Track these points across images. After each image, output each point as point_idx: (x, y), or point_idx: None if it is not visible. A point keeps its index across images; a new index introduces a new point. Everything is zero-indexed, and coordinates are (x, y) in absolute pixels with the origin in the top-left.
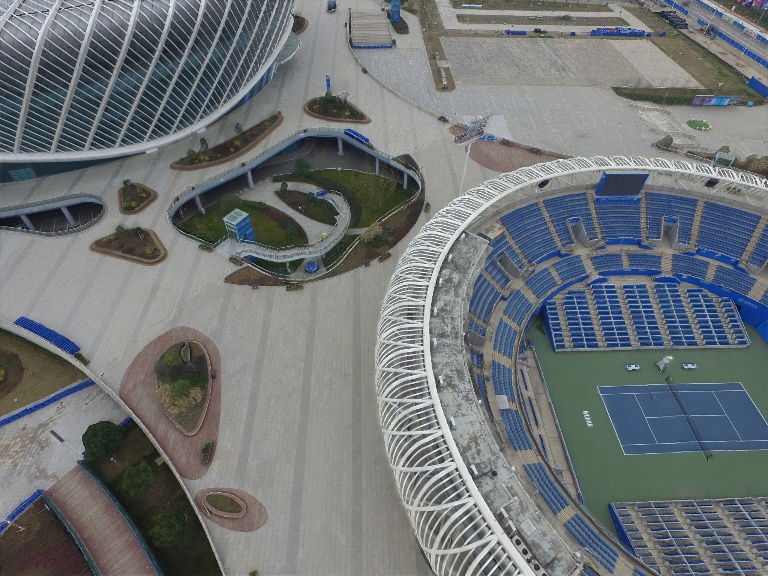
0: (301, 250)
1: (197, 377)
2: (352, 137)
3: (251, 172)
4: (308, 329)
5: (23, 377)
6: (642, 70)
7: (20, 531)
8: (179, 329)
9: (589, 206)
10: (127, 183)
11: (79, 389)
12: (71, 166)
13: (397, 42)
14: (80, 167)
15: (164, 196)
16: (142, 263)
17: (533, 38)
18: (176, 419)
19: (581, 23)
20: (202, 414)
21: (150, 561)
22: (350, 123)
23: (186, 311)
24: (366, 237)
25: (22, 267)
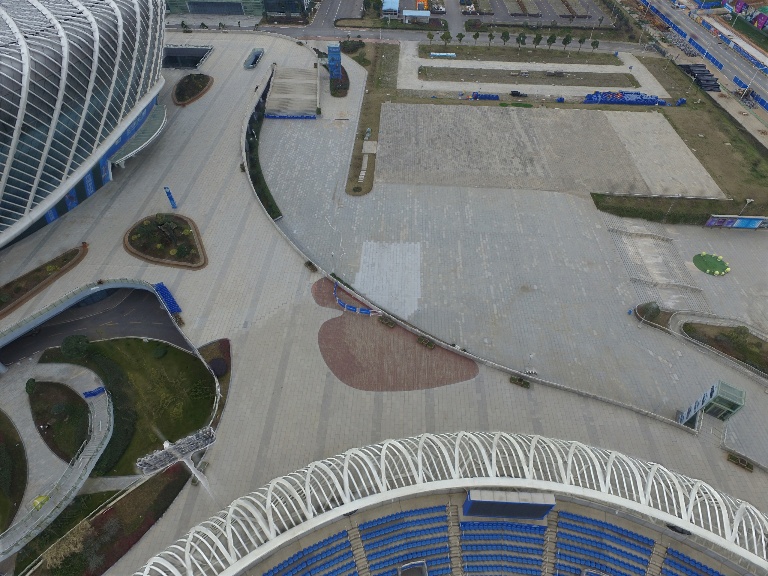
0: None
1: None
2: None
3: None
4: None
5: None
6: (641, 164)
7: None
8: None
9: (448, 534)
10: None
11: None
12: None
13: (326, 109)
14: None
15: None
16: None
17: (504, 107)
18: None
19: (576, 82)
20: None
21: None
22: (174, 267)
23: None
24: (48, 561)
25: None
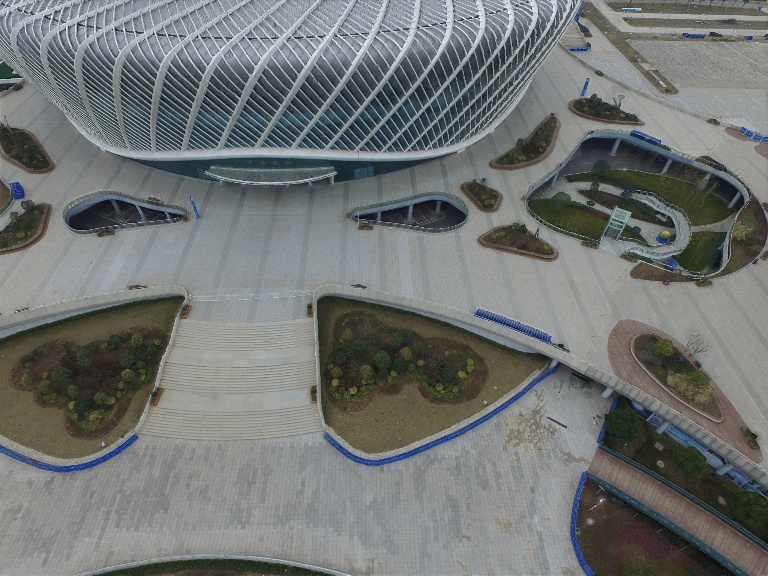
0: (668, 248)
1: (688, 367)
2: (641, 138)
3: (558, 172)
4: (748, 323)
5: (487, 366)
6: None
7: (591, 510)
8: (627, 322)
9: None
10: (480, 182)
11: (543, 378)
12: (404, 165)
13: None
14: (407, 166)
15: (508, 195)
16: (541, 259)
17: (717, 42)
18: (697, 406)
19: (748, 27)
20: (717, 402)
21: (758, 538)
22: (626, 125)
23: (619, 305)
24: (740, 236)
25: (431, 262)
